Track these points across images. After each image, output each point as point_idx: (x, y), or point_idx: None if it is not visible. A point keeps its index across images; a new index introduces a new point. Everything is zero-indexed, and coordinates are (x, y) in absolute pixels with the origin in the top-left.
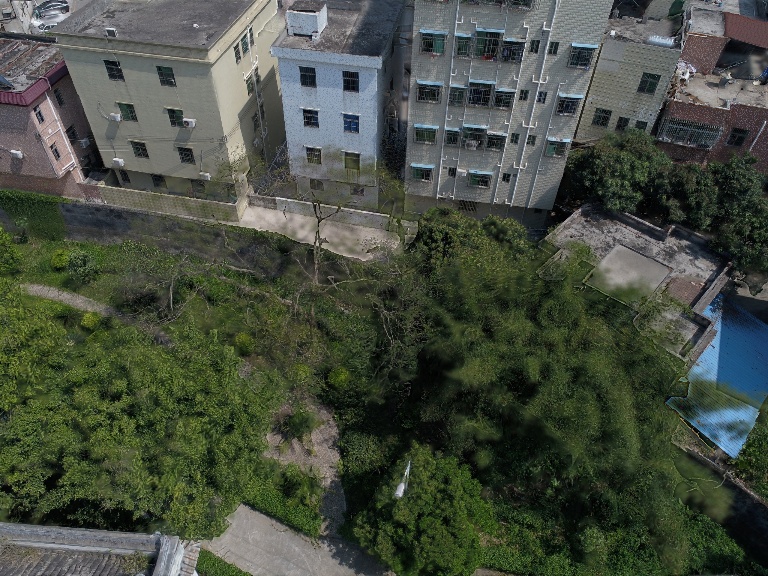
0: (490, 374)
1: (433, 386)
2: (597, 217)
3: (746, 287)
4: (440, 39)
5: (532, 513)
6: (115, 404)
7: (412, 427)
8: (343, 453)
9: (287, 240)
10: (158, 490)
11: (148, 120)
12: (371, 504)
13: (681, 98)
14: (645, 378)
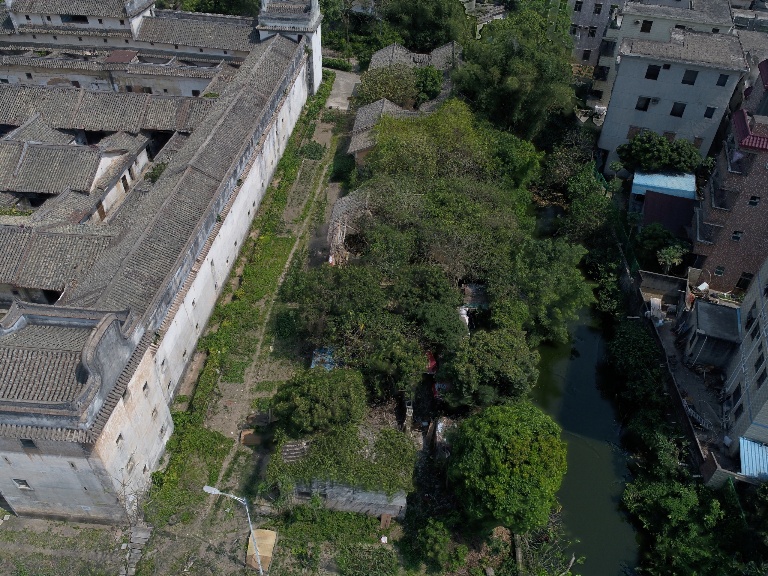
0: None
1: None
2: None
3: None
4: None
5: None
6: None
7: None
8: (359, 58)
9: None
10: None
11: None
12: None
13: None
14: None
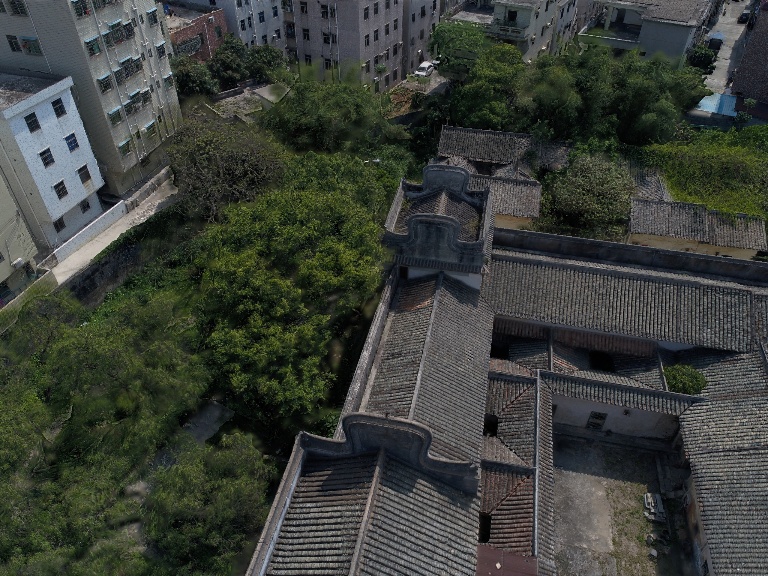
0: None
1: None
2: (212, 105)
3: None
4: (95, 43)
5: None
6: None
7: None
8: None
9: (139, 226)
10: None
11: None
12: None
13: None
14: None
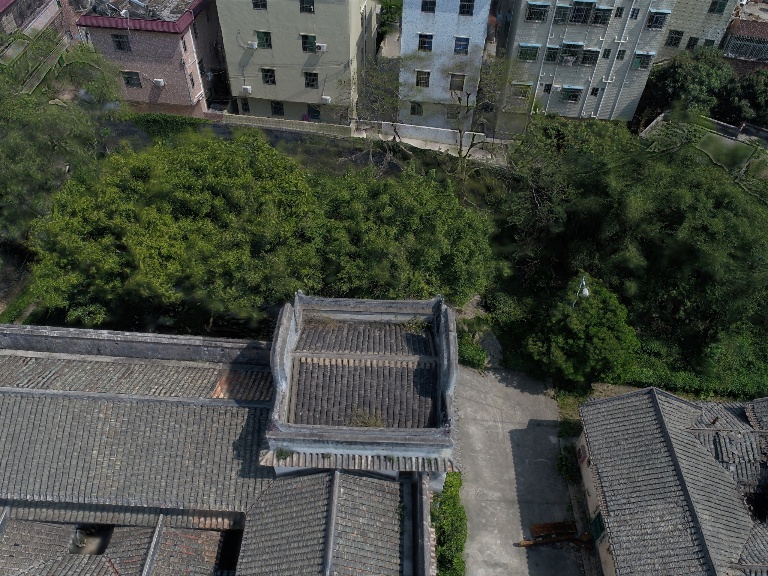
0: (640, 211)
1: (574, 240)
2: (676, 121)
3: None
4: None
5: (658, 343)
6: (379, 214)
7: (546, 286)
8: (490, 309)
9: (412, 147)
10: (413, 283)
11: (282, 47)
12: (538, 328)
13: (745, 17)
14: (764, 208)
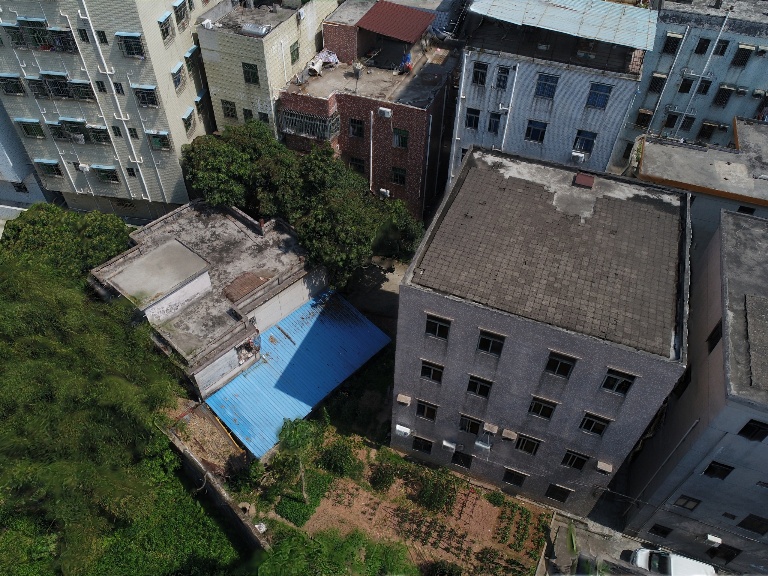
0: None
1: None
2: (211, 212)
3: (392, 281)
4: None
5: (25, 519)
6: None
7: None
8: None
9: None
10: None
11: None
12: None
13: (289, 88)
14: (46, 378)
